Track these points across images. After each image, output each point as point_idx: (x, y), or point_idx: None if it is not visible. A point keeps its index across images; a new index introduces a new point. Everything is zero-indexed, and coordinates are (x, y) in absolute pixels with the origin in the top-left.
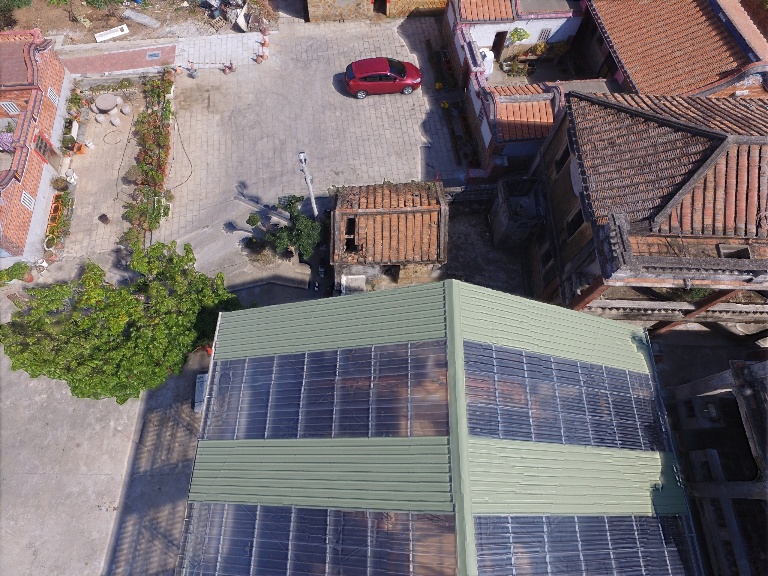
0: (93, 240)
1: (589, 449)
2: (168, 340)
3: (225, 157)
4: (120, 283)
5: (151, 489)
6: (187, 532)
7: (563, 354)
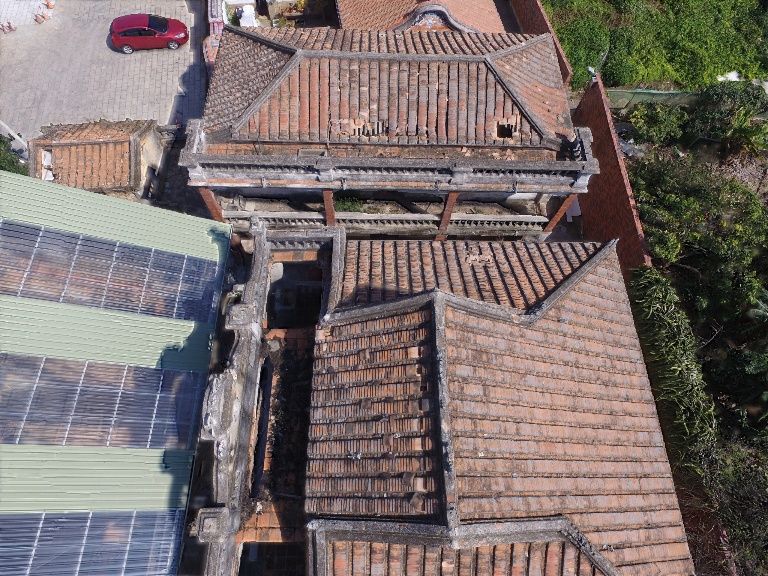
0: None
1: (95, 310)
2: None
3: None
4: None
5: None
6: None
7: (100, 234)
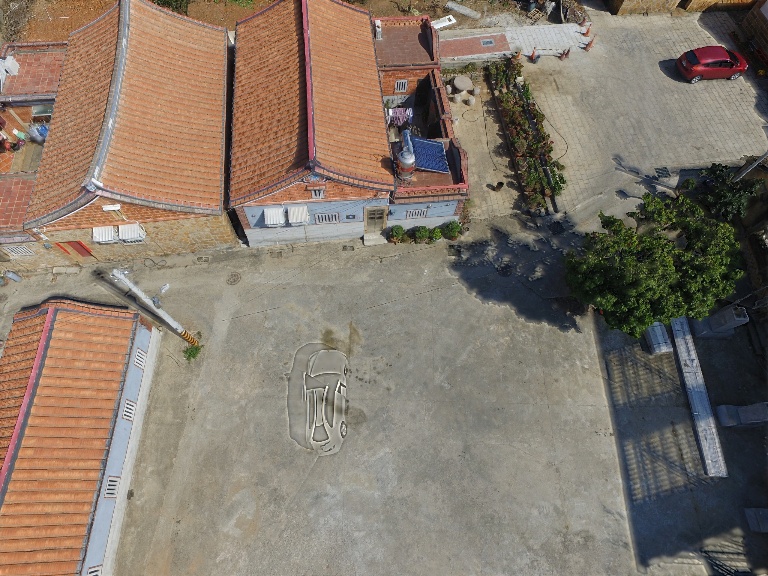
0: (490, 205)
1: None
2: None
3: (592, 133)
4: (537, 242)
5: (636, 418)
6: None
7: None
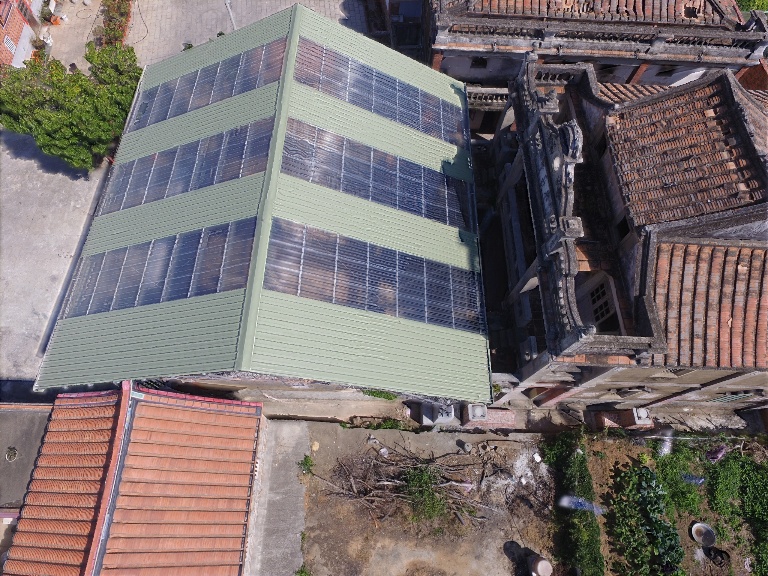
0: None
1: (394, 123)
2: (110, 102)
3: (176, 24)
4: None
5: None
6: (109, 181)
7: (385, 71)
